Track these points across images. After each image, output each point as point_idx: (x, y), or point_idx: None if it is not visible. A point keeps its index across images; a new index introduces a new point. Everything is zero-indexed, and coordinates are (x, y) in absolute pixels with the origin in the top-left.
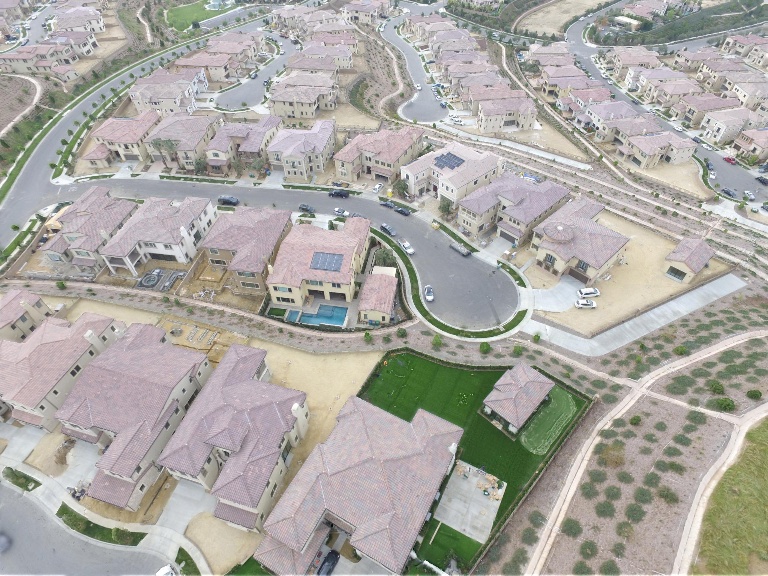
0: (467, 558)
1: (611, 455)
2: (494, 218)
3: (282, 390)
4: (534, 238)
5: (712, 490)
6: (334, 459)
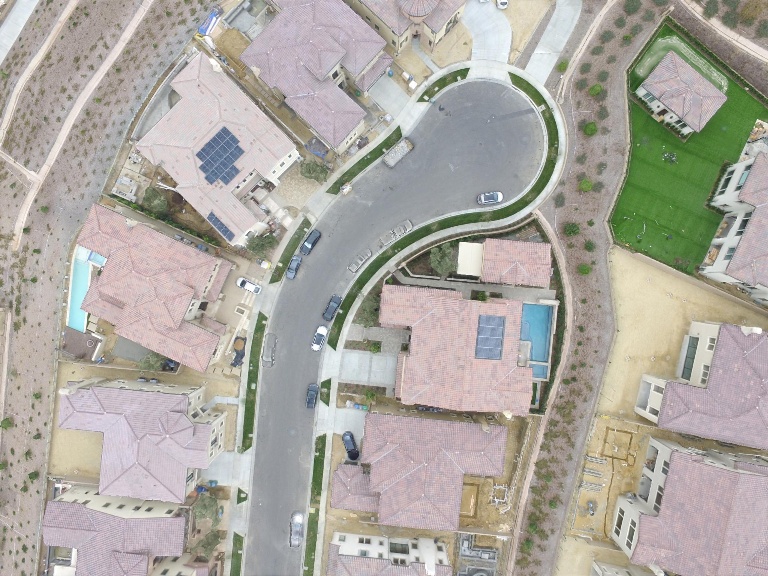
0: None
1: (746, 10)
2: None
3: (723, 351)
4: (401, 38)
5: None
6: None
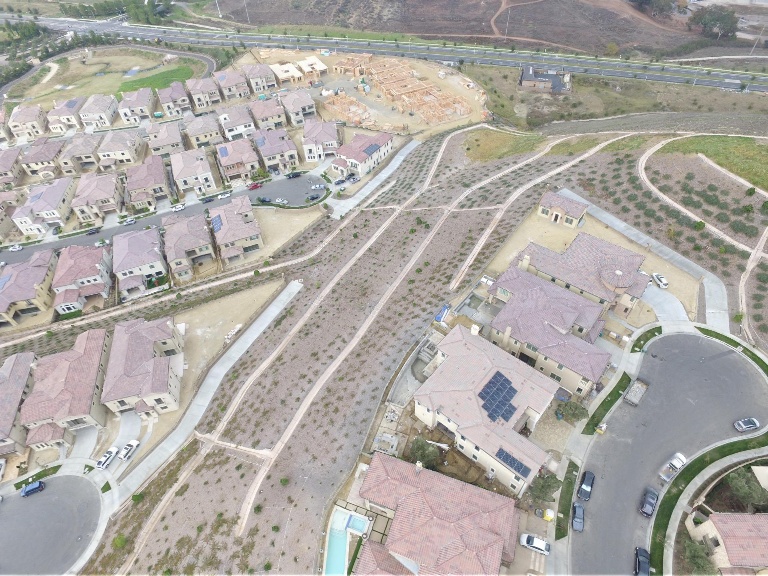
0: None
1: None
2: None
3: None
4: None
5: None
6: None
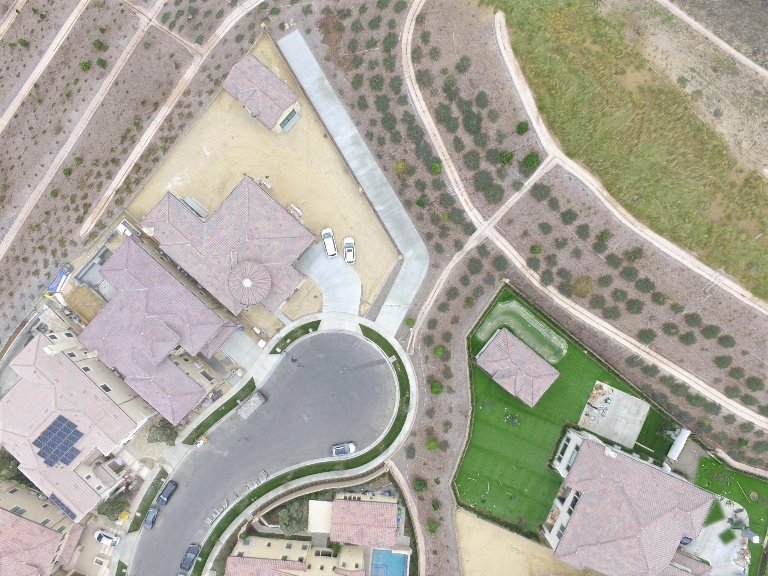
0: (662, 420)
1: (578, 286)
2: (183, 356)
3: None
4: None
5: (630, 215)
6: (631, 568)
